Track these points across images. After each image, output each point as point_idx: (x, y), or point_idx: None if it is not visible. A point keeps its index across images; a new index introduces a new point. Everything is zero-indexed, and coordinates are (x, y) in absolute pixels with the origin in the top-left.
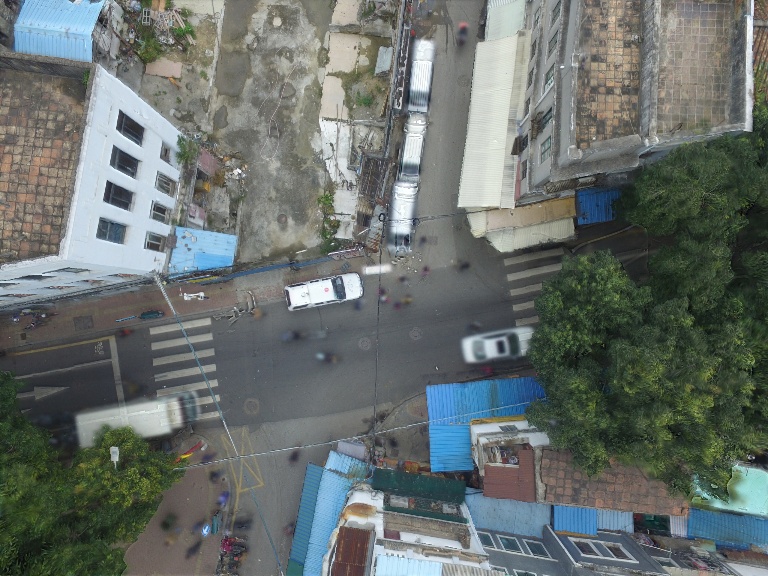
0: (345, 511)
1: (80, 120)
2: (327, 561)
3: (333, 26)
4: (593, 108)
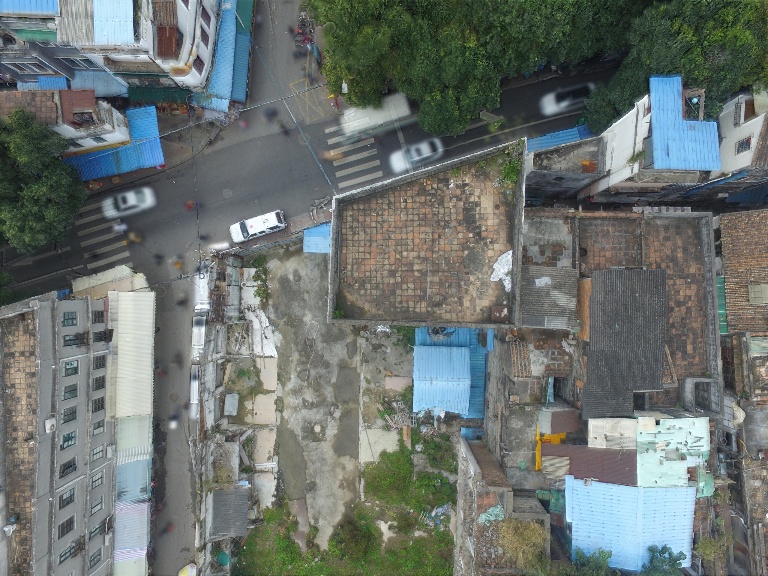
0: (189, 71)
1: (349, 292)
2: (197, 38)
3: (272, 427)
4: (32, 341)
